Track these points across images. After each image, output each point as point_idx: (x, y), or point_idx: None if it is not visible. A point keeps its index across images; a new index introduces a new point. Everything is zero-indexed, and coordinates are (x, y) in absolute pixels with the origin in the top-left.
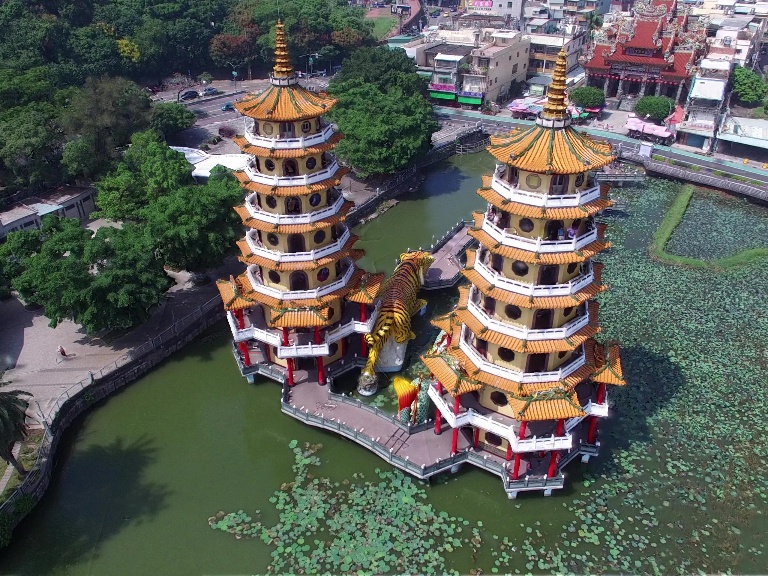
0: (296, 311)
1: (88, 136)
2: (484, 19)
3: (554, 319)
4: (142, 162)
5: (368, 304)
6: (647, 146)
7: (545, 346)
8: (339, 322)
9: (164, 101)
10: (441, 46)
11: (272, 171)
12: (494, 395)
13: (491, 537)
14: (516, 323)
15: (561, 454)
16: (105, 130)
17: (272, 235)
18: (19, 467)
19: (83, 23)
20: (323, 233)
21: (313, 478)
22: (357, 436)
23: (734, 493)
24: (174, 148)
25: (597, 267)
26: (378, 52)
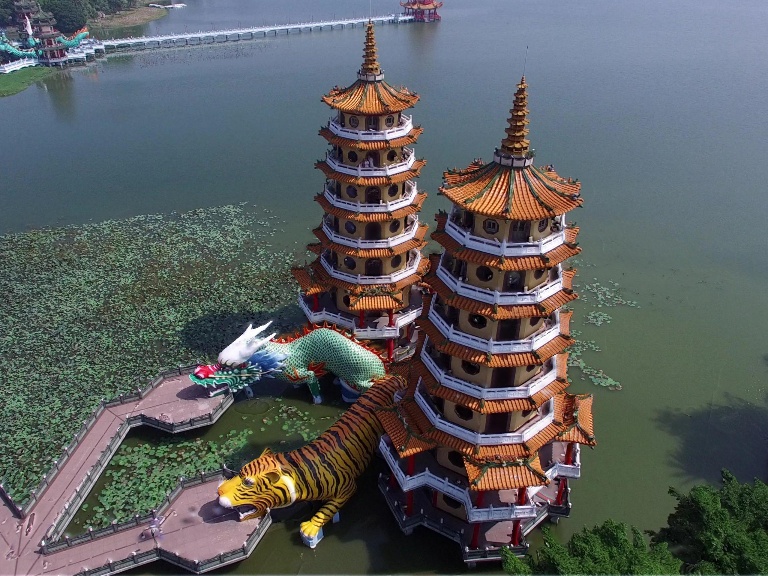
0: None
1: None
2: None
3: None
4: None
5: None
6: None
7: None
8: None
9: None
10: None
11: None
12: None
13: None
14: None
15: None
16: None
17: None
18: None
19: None
20: None
21: None
22: None
23: None
24: None
25: None
26: None
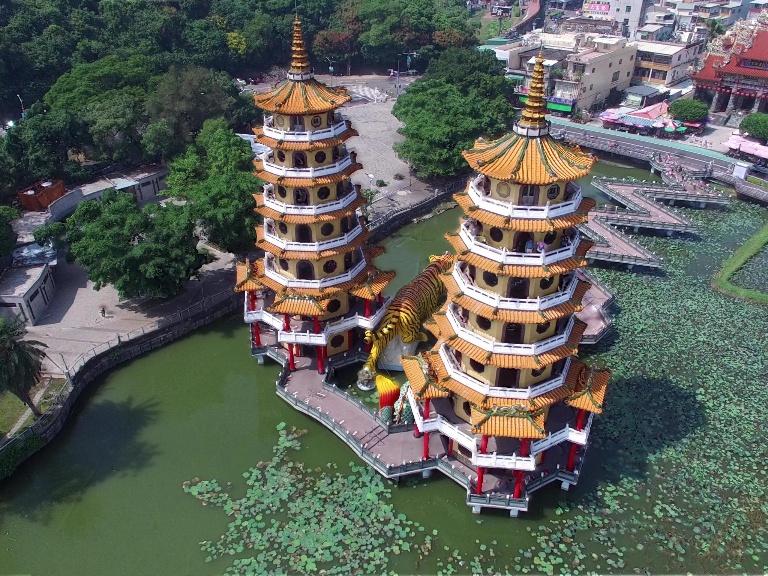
0: (296, 299)
1: (171, 120)
2: (590, 23)
3: (525, 334)
4: (210, 147)
5: (377, 301)
6: (742, 167)
7: (510, 361)
8: (344, 315)
9: (254, 92)
10: (538, 50)
11: (283, 162)
12: (466, 405)
13: (442, 547)
14: (486, 334)
15: (533, 476)
16: (183, 115)
17: (282, 224)
18: (35, 409)
19: (201, 16)
20: (331, 226)
21: (289, 461)
22: (335, 427)
23: (721, 549)
24: (251, 136)
25: (583, 286)
26: (466, 53)
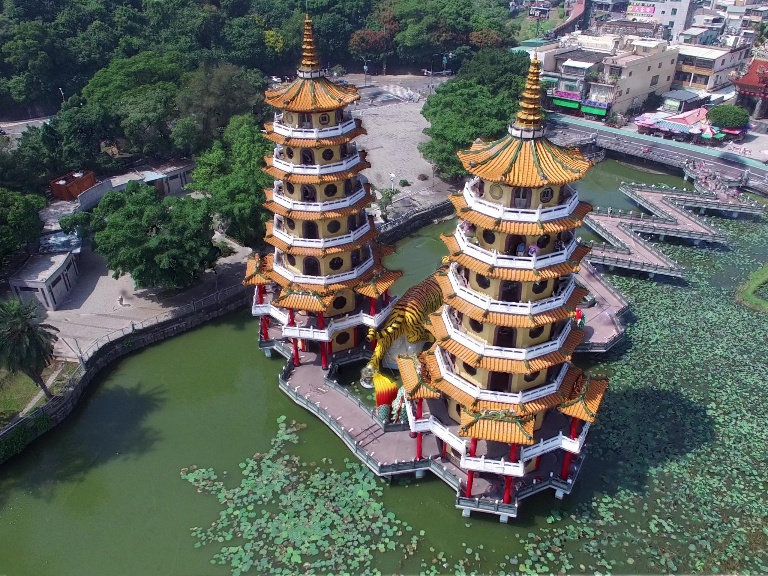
0: (300, 294)
1: (201, 115)
2: (631, 26)
3: (517, 339)
4: (235, 142)
5: (384, 299)
6: None
7: (501, 365)
8: (350, 312)
9: None
10: (575, 52)
11: (292, 158)
12: (459, 407)
13: (427, 548)
14: (479, 336)
15: (525, 483)
16: (212, 111)
17: (290, 219)
18: (47, 391)
19: (241, 14)
20: (338, 223)
21: (285, 454)
22: (331, 422)
23: (715, 569)
24: None
25: (579, 292)
26: (499, 54)
